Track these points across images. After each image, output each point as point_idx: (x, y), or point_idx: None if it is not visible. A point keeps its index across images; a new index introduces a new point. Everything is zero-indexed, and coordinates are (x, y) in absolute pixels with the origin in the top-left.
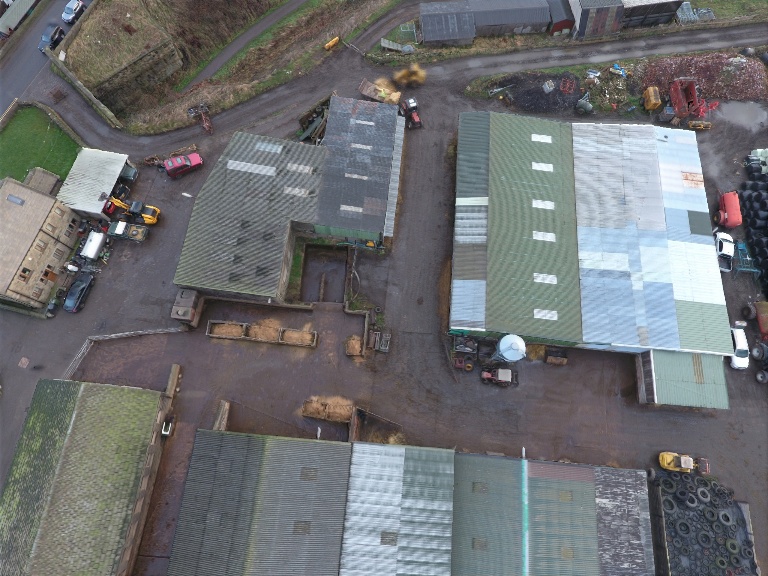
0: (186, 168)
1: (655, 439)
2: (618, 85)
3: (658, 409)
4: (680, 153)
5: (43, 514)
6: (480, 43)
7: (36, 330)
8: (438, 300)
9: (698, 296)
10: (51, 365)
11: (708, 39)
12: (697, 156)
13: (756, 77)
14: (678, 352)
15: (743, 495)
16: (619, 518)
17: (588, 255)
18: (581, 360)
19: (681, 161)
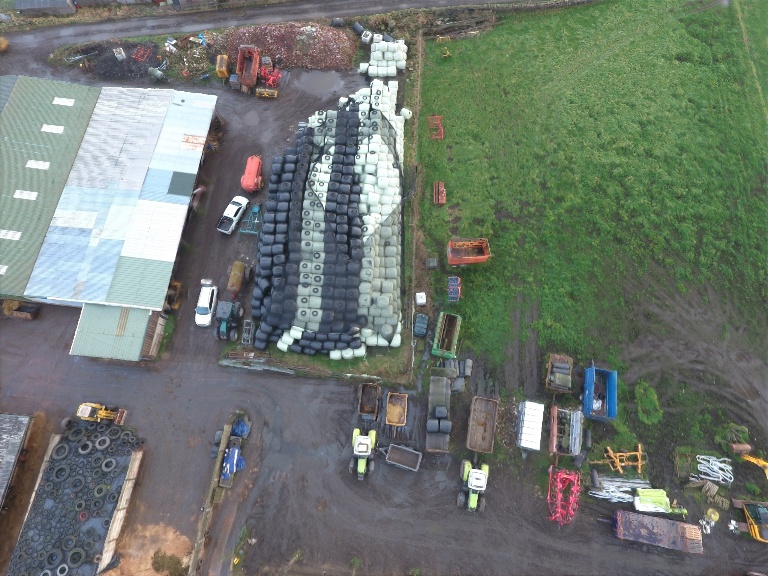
0: None
1: (92, 391)
2: (195, 53)
3: (107, 363)
4: (191, 117)
5: None
6: (83, 13)
7: None
8: None
9: (147, 253)
10: None
11: (308, 10)
12: (208, 120)
13: (332, 46)
14: (109, 306)
15: (154, 445)
16: None
17: (63, 213)
18: (51, 316)
19: (190, 124)
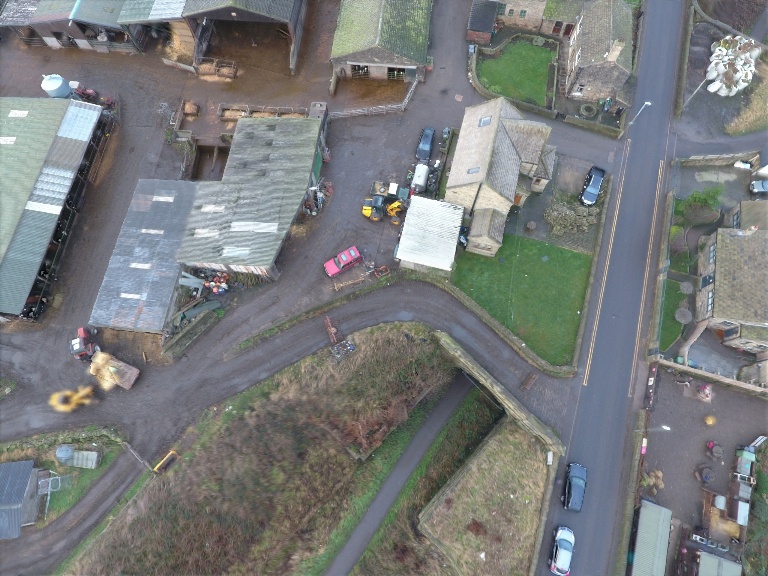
0: None
1: None
2: None
3: None
4: None
5: None
6: None
7: (457, 121)
8: (116, 152)
9: None
10: (435, 95)
11: None
12: None
13: None
14: None
15: None
16: (26, 2)
17: None
18: None
19: None
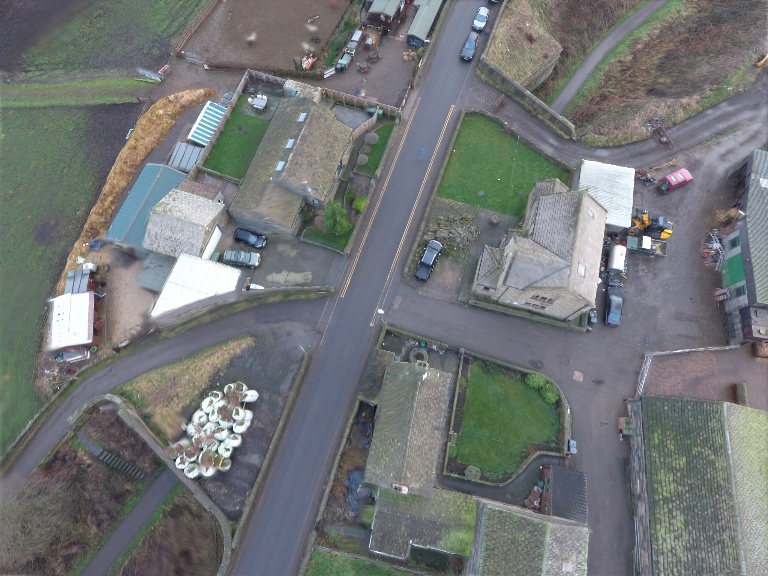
0: (682, 183)
1: None
2: None
3: None
4: None
5: (738, 535)
6: None
7: (577, 343)
8: None
9: None
10: (609, 380)
11: None
12: None
13: None
14: None
15: None
16: None
17: None
18: None
19: None
